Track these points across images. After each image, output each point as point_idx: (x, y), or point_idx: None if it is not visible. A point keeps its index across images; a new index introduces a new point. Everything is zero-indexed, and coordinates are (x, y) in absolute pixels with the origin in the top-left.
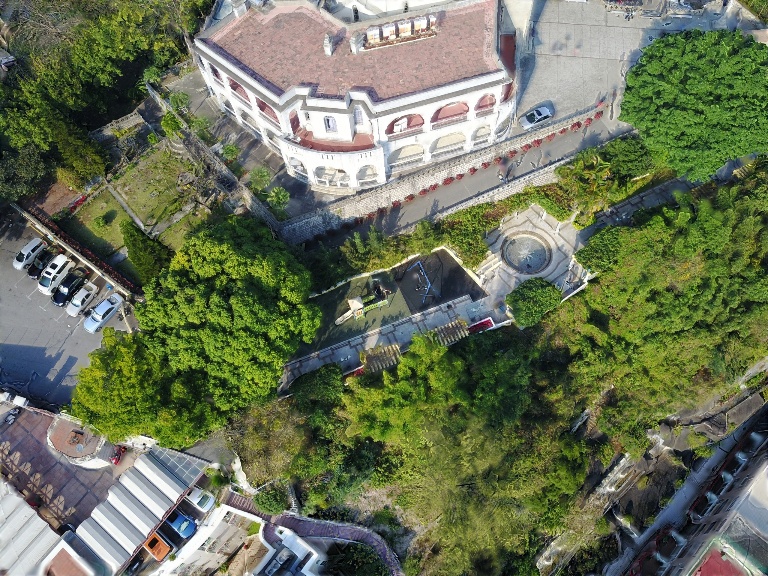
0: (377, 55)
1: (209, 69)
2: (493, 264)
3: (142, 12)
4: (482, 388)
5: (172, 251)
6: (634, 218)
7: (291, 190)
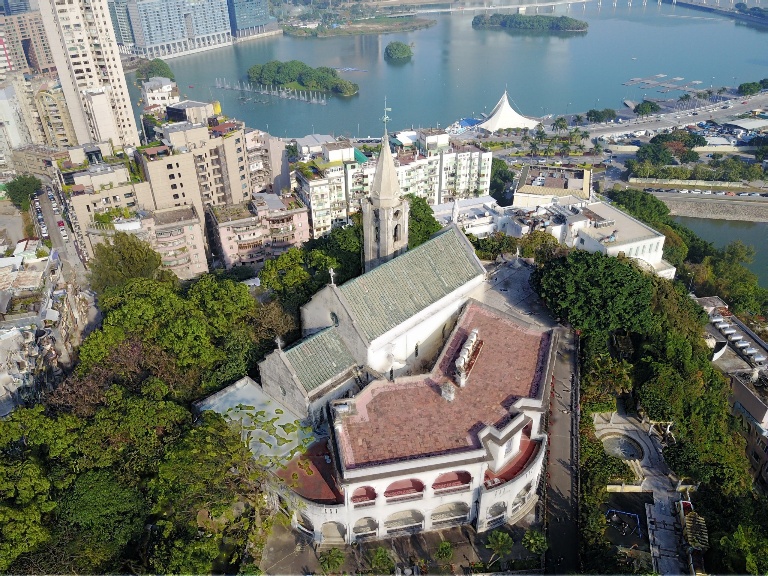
0: (476, 377)
1: (350, 499)
2: (636, 466)
3: (115, 546)
4: (764, 538)
5: None
6: (631, 379)
7: None
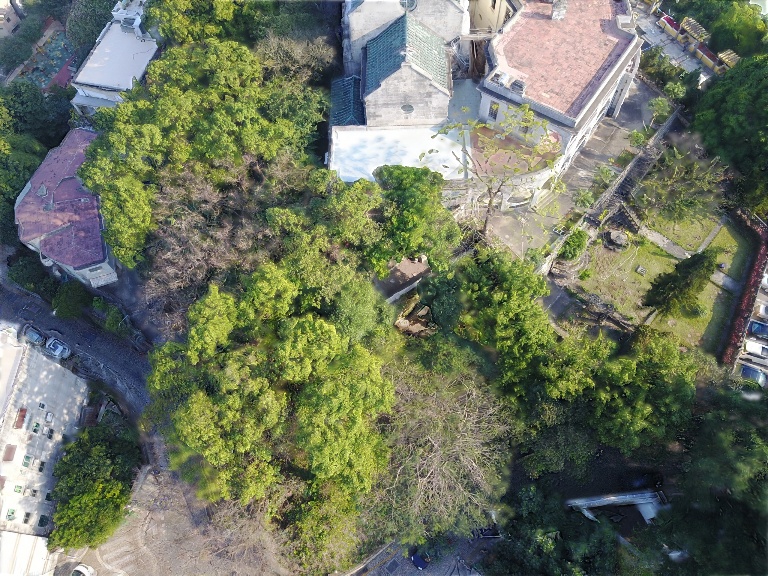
0: None
1: None
2: None
3: None
4: None
5: (755, 171)
6: None
7: (633, 113)
